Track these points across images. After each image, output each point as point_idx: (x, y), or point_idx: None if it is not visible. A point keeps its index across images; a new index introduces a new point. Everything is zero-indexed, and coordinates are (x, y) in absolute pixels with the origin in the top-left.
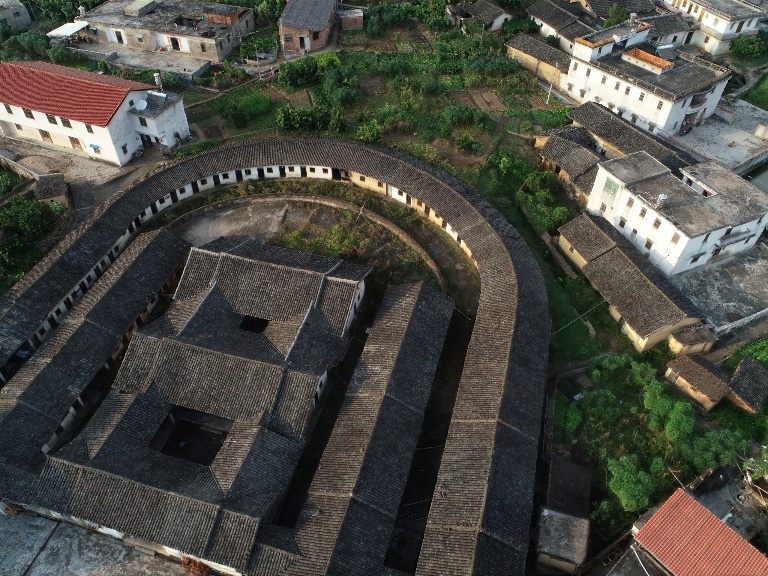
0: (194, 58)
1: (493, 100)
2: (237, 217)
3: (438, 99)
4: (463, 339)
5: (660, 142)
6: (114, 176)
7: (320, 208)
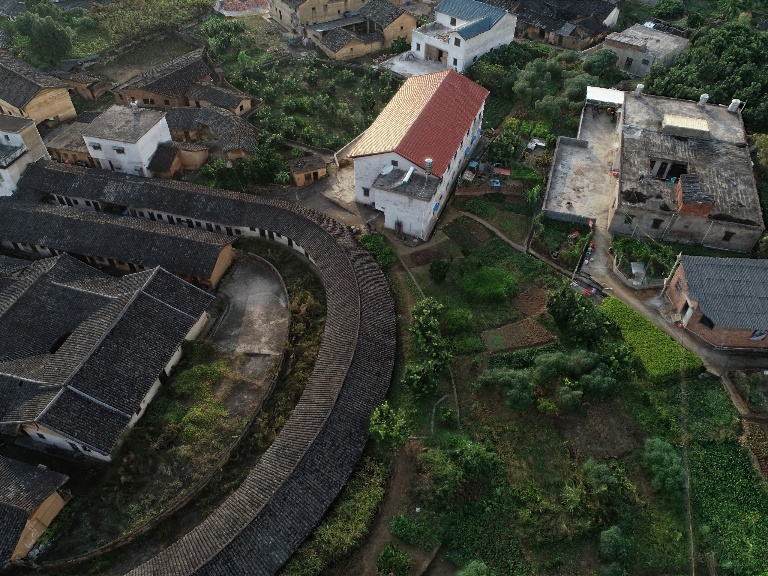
0: (609, 206)
1: None
2: (272, 312)
3: (590, 571)
4: None
5: None
6: (338, 200)
7: (262, 390)
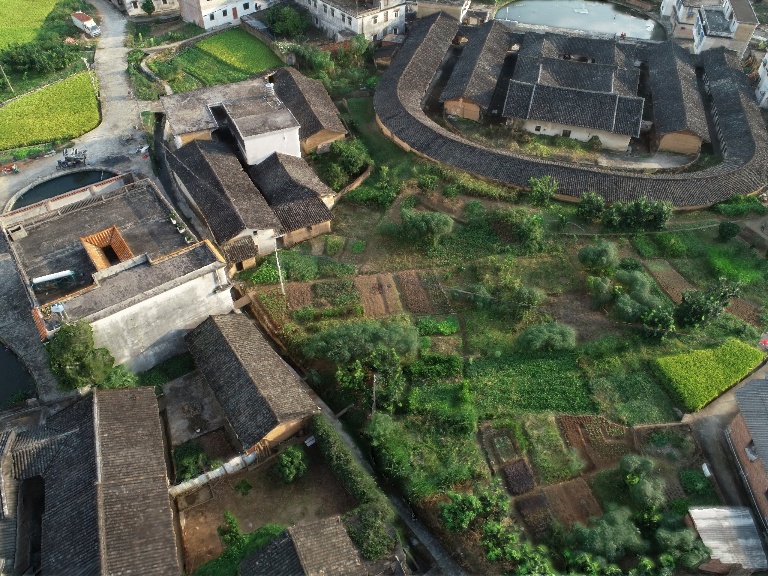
0: None
1: (370, 295)
2: None
3: None
4: None
5: (201, 170)
6: None
7: None
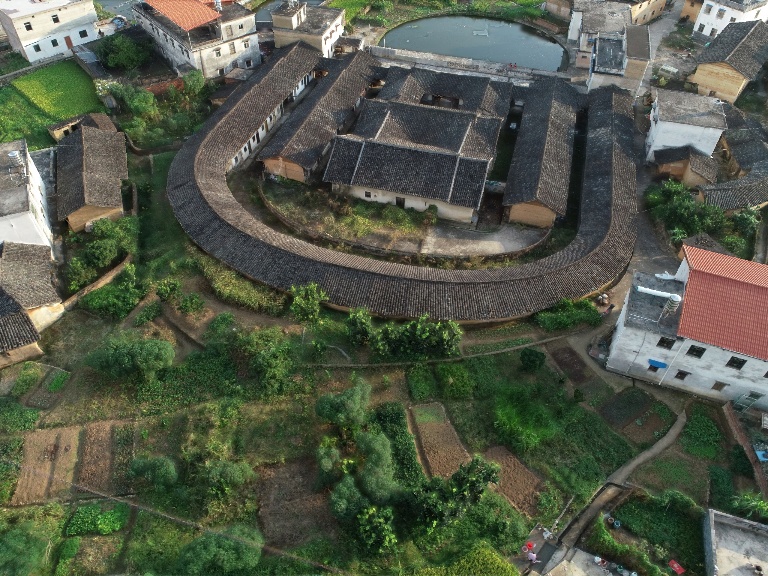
0: None
1: (36, 464)
2: None
3: None
4: (255, 170)
5: None
6: None
7: None
